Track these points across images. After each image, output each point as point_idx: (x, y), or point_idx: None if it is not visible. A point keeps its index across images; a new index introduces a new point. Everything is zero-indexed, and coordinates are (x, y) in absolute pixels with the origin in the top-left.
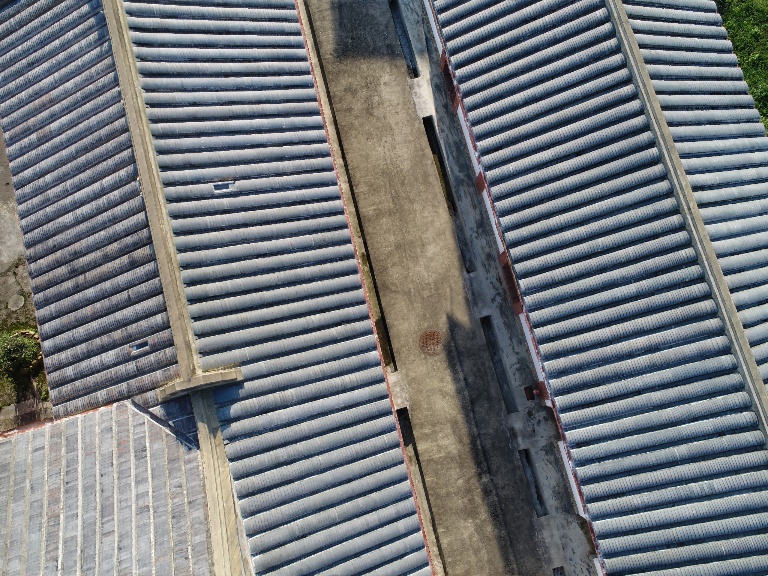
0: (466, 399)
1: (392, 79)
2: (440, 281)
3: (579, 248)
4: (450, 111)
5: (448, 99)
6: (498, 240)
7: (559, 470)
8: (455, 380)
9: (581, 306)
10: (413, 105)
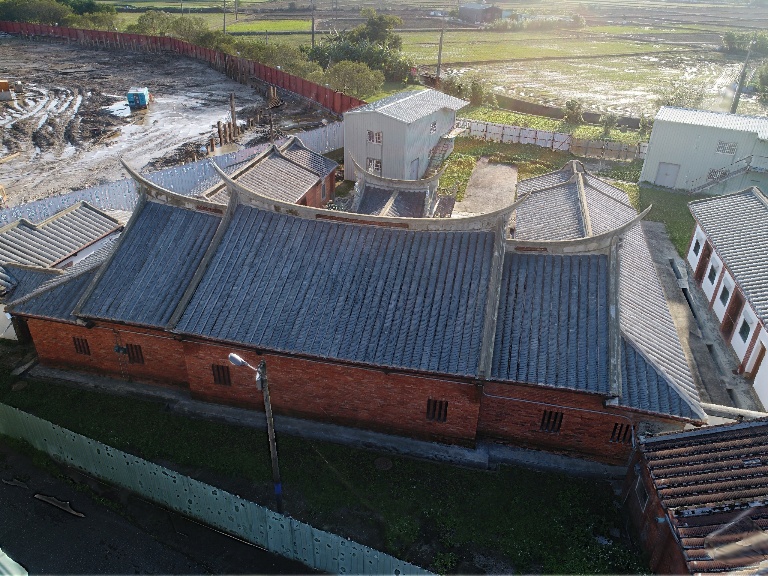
0: (694, 363)
1: (667, 276)
2: (684, 328)
3: (764, 265)
4: (697, 289)
5: (696, 286)
6: (720, 318)
7: (753, 401)
8: (688, 356)
9: (765, 277)
10: (677, 284)
